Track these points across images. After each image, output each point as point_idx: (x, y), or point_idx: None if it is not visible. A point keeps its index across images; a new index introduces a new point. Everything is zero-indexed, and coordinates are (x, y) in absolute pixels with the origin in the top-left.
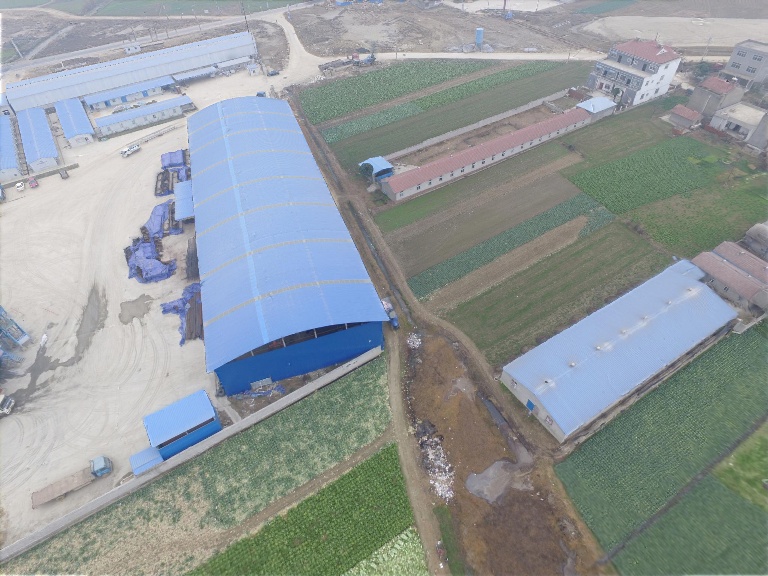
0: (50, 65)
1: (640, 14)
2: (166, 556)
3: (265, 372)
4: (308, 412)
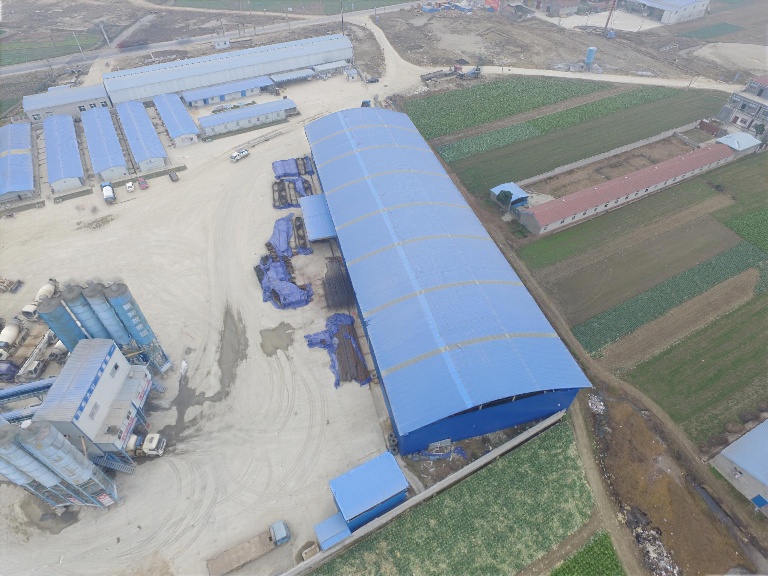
0: (139, 55)
1: (751, 42)
2: None
3: (447, 433)
4: (497, 484)
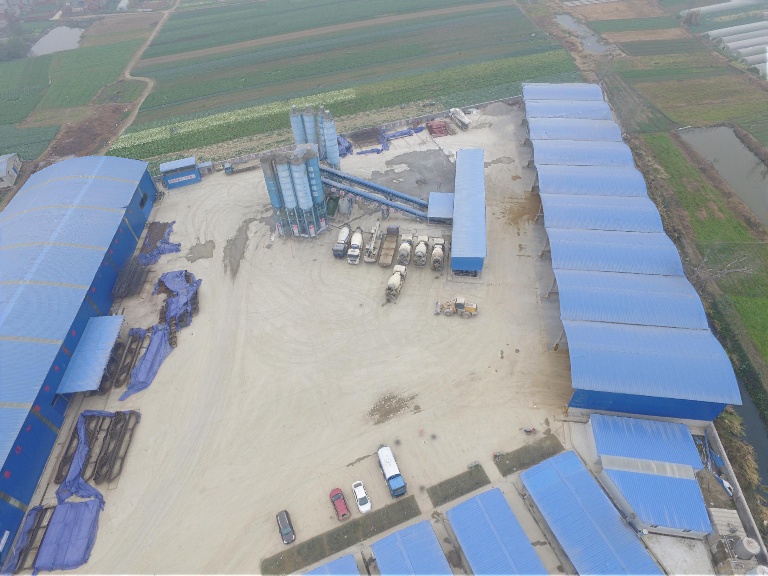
0: None
1: None
2: (207, 150)
3: None
4: None
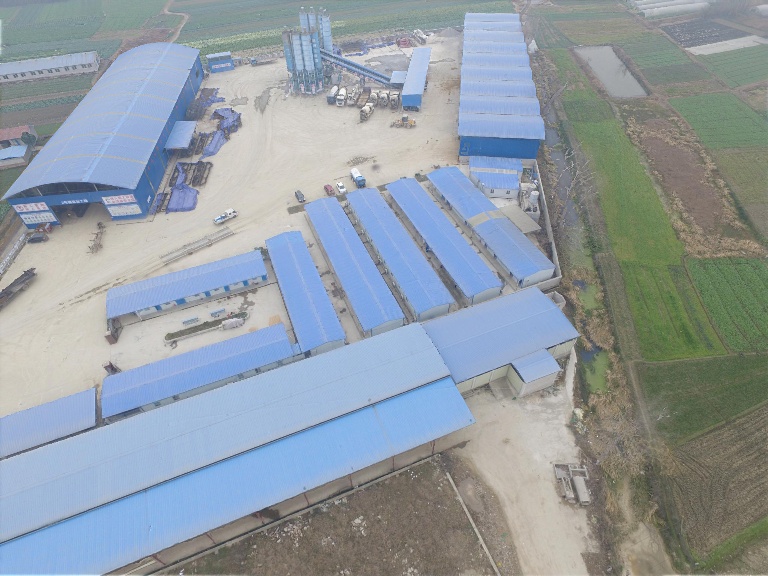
0: None
1: None
2: (237, 53)
3: None
4: None
